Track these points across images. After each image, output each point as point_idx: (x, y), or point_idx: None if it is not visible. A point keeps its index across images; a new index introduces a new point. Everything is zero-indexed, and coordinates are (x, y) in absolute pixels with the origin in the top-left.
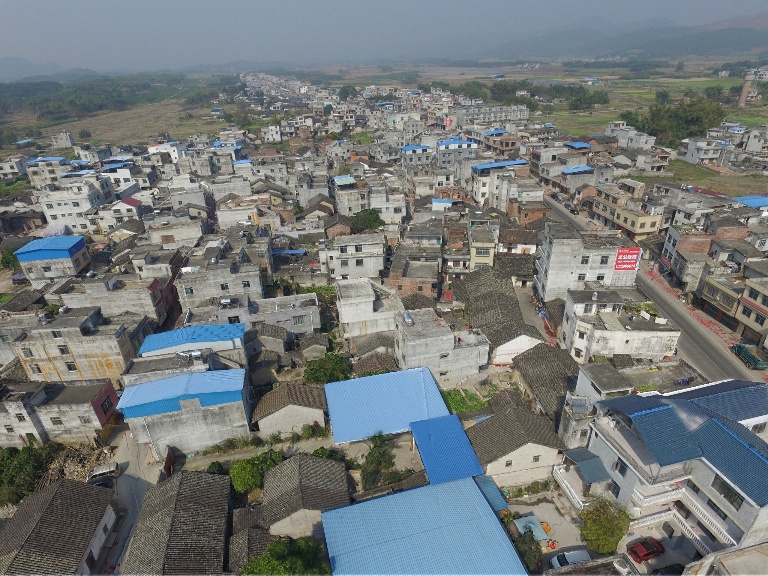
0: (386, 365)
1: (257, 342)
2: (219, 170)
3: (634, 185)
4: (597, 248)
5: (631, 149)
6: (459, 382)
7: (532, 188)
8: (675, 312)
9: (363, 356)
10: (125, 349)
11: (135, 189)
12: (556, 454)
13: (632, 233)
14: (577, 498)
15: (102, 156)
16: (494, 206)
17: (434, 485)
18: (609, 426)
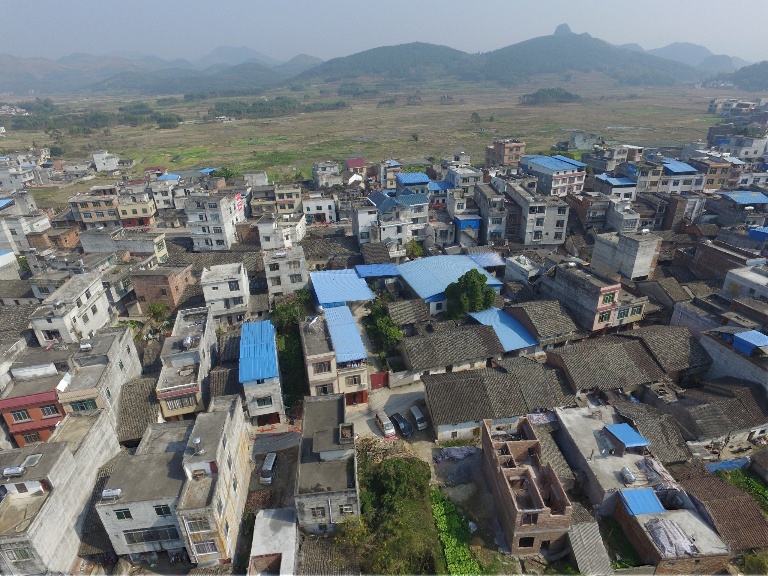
0: None
1: None
2: None
3: (112, 187)
4: (231, 200)
5: None
6: None
7: (37, 218)
8: None
9: (271, 307)
10: None
11: None
12: None
13: (147, 218)
14: (402, 251)
15: None
16: None
17: None
18: None
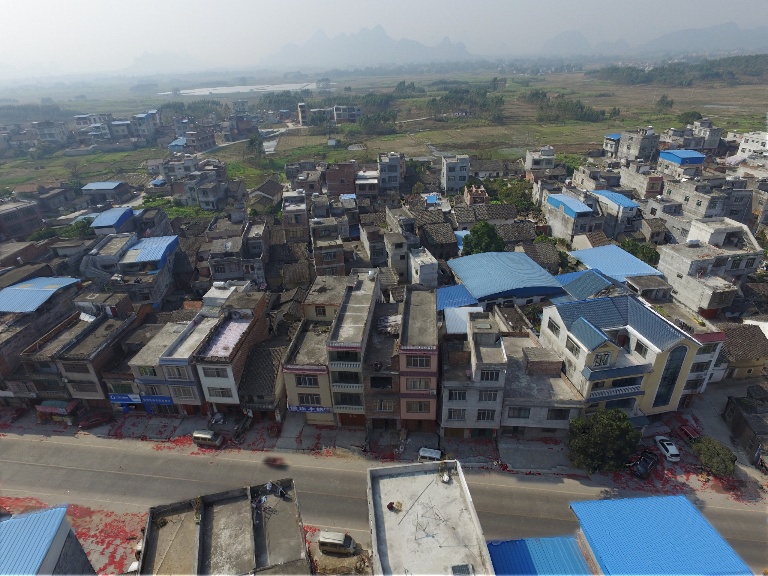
0: None
1: (640, 223)
2: None
3: None
4: None
5: None
6: None
7: None
8: None
9: None
10: None
11: None
12: None
13: None
14: None
15: None
16: None
17: (553, 277)
18: None
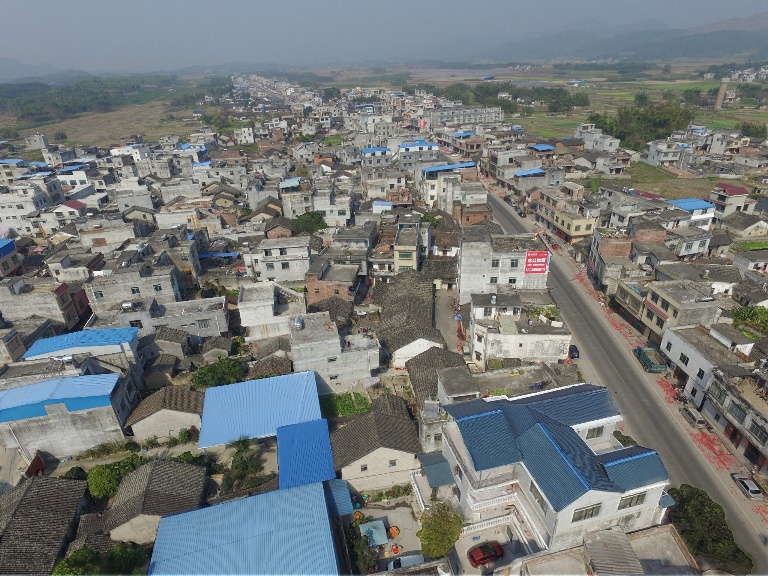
0: (279, 369)
1: (154, 346)
2: (180, 172)
3: (572, 188)
4: (506, 251)
5: (595, 151)
6: (350, 386)
7: (475, 191)
8: (591, 315)
9: (261, 360)
10: (17, 353)
11: (89, 191)
12: (413, 458)
13: (568, 236)
14: (421, 502)
15: (66, 158)
16: (442, 209)
17: (282, 490)
18: (457, 430)
